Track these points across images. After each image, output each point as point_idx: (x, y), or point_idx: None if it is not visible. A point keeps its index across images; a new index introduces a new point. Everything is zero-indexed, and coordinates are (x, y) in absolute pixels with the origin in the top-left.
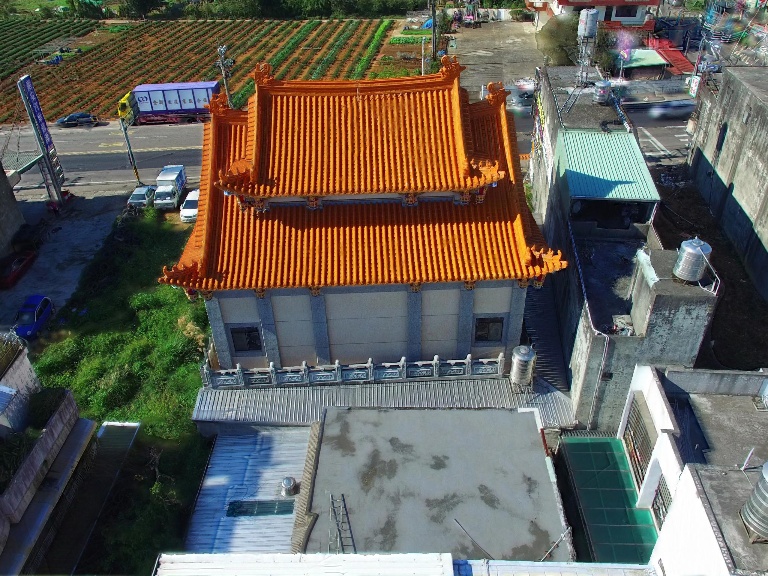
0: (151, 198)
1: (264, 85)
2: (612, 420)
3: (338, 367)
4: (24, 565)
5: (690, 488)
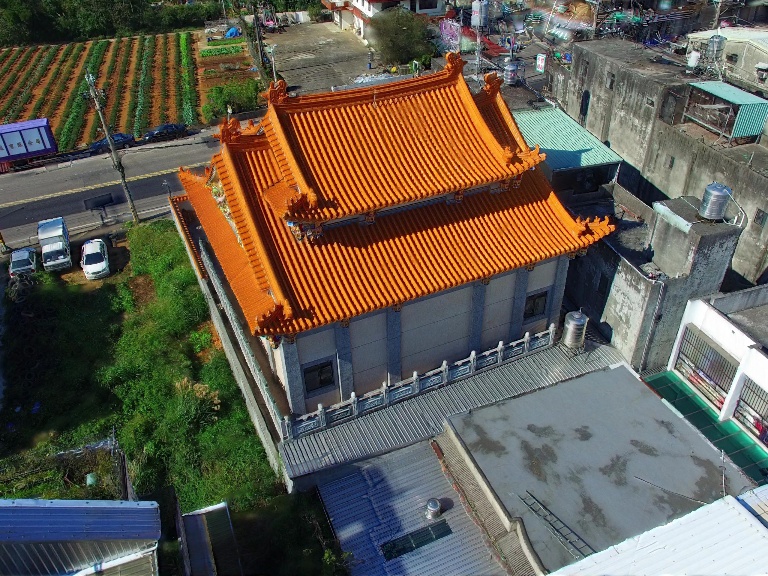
0: (39, 261)
1: (279, 104)
2: (657, 357)
3: (417, 378)
4: None
5: None
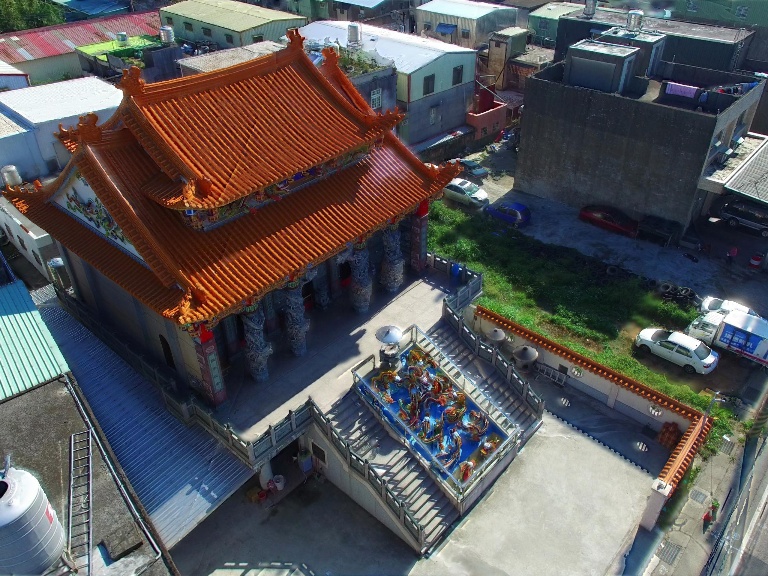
0: None
1: None
2: None
3: None
4: None
5: None
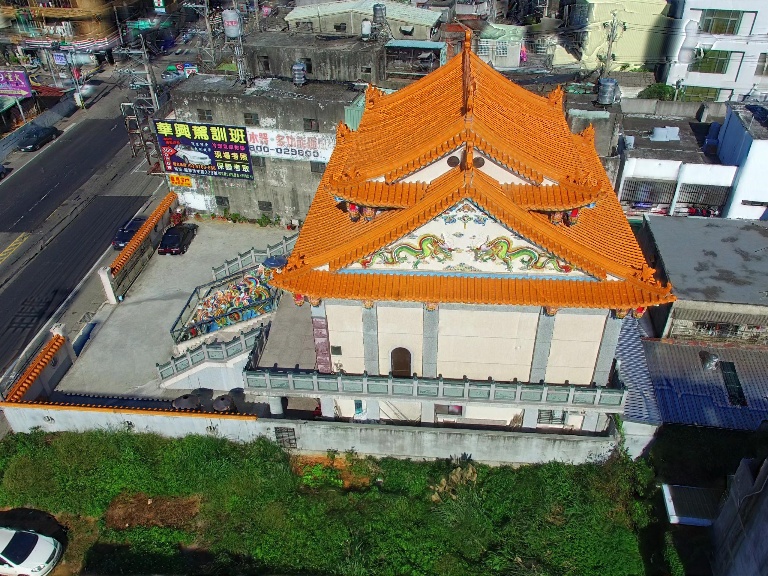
0: None
1: None
2: None
3: None
4: None
5: (764, 145)
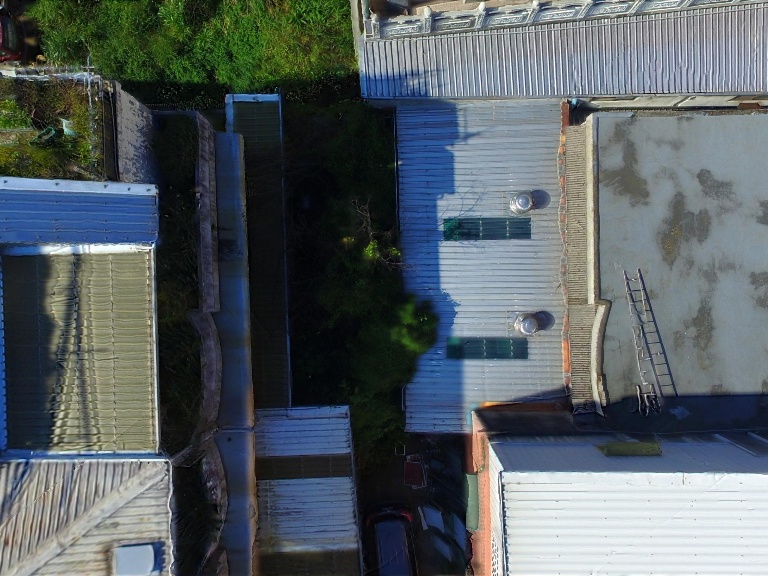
0: None
1: None
2: None
3: (589, 3)
4: (251, 357)
5: None
